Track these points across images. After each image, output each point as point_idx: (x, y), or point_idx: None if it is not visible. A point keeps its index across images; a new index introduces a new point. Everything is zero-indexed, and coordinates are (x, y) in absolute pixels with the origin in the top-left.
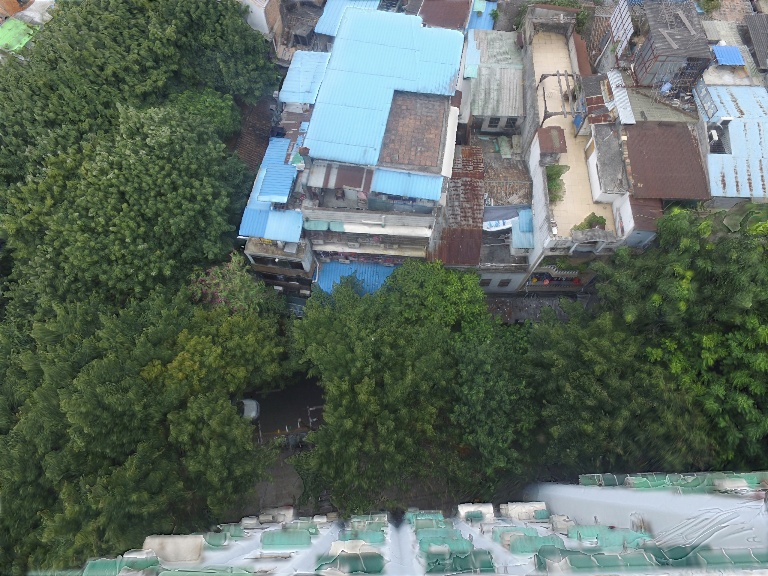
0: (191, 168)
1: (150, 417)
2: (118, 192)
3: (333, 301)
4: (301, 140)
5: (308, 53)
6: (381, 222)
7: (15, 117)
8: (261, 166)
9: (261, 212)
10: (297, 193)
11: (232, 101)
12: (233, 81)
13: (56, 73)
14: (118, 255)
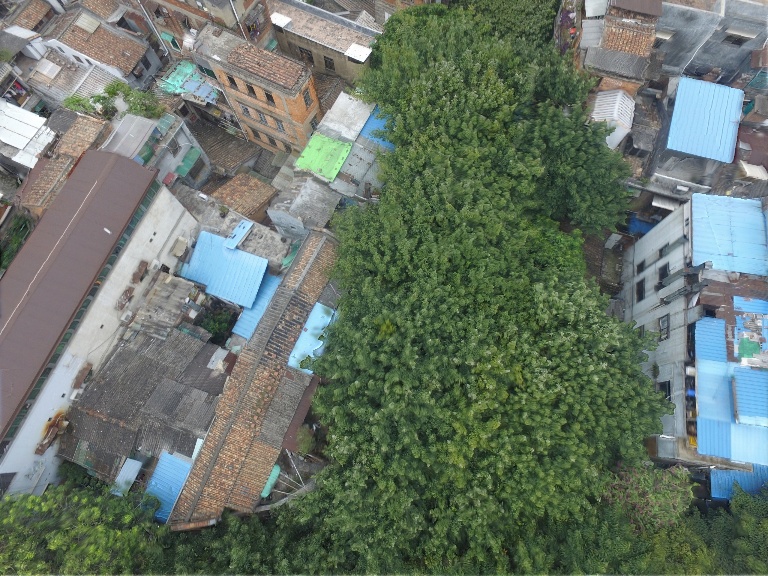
0: (634, 369)
1: None
2: (568, 409)
3: (764, 507)
4: (742, 323)
5: (711, 197)
6: None
7: (432, 311)
8: (696, 356)
9: (720, 424)
10: None
11: (583, 238)
12: (587, 215)
13: (449, 241)
14: (573, 486)
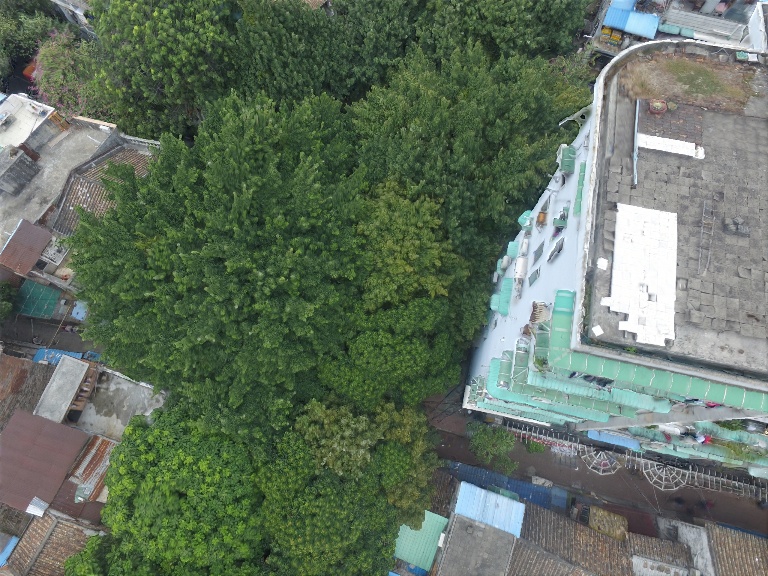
0: None
1: (547, 127)
2: None
3: None
4: None
5: None
6: (730, 34)
7: None
8: None
9: (623, 11)
10: (654, 2)
11: None
12: None
13: None
14: (512, 18)
